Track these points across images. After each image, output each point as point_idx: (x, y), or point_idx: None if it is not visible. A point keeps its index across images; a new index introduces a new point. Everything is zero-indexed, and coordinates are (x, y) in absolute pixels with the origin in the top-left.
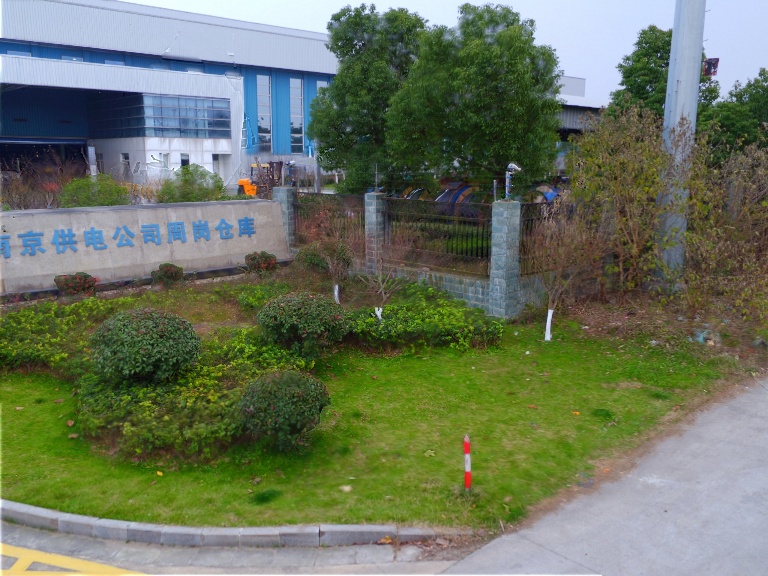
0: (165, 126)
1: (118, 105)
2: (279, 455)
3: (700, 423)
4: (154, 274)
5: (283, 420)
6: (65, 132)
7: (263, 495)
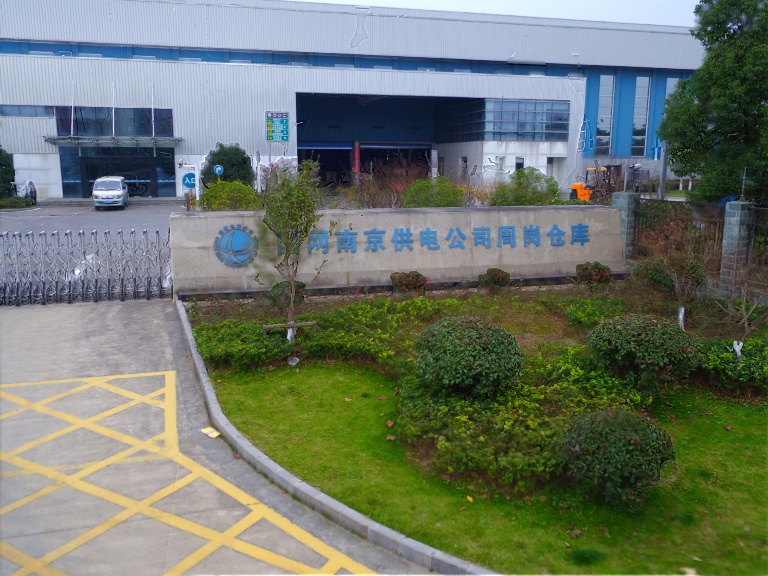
0: (503, 130)
1: (462, 111)
2: (604, 507)
3: None
4: (481, 278)
5: (614, 469)
6: (414, 137)
7: (583, 554)
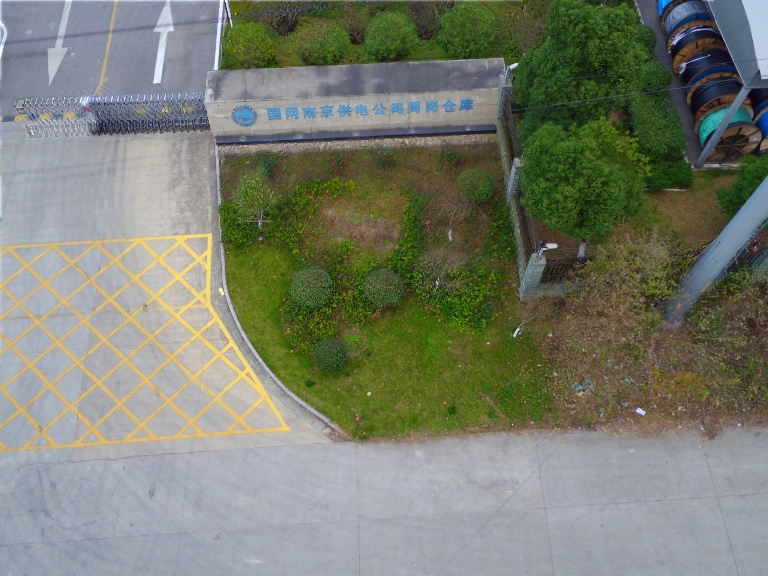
0: None
1: None
2: None
3: (478, 440)
4: (378, 159)
5: None
6: None
7: (309, 383)
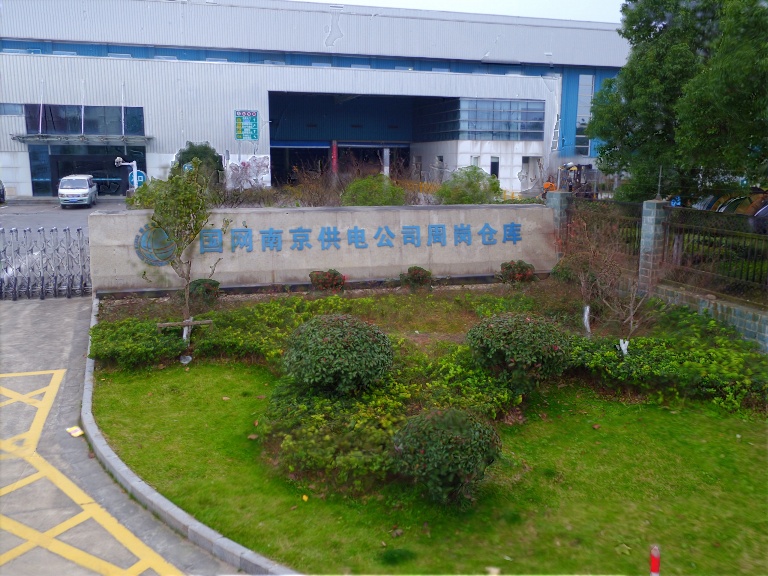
0: (478, 129)
1: (438, 110)
2: (434, 506)
3: None
4: (402, 276)
5: (432, 468)
6: (392, 137)
7: (392, 554)
